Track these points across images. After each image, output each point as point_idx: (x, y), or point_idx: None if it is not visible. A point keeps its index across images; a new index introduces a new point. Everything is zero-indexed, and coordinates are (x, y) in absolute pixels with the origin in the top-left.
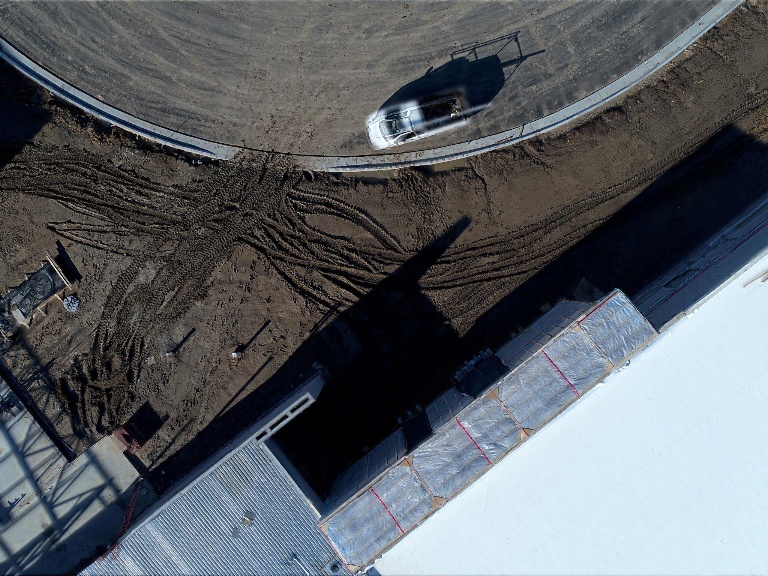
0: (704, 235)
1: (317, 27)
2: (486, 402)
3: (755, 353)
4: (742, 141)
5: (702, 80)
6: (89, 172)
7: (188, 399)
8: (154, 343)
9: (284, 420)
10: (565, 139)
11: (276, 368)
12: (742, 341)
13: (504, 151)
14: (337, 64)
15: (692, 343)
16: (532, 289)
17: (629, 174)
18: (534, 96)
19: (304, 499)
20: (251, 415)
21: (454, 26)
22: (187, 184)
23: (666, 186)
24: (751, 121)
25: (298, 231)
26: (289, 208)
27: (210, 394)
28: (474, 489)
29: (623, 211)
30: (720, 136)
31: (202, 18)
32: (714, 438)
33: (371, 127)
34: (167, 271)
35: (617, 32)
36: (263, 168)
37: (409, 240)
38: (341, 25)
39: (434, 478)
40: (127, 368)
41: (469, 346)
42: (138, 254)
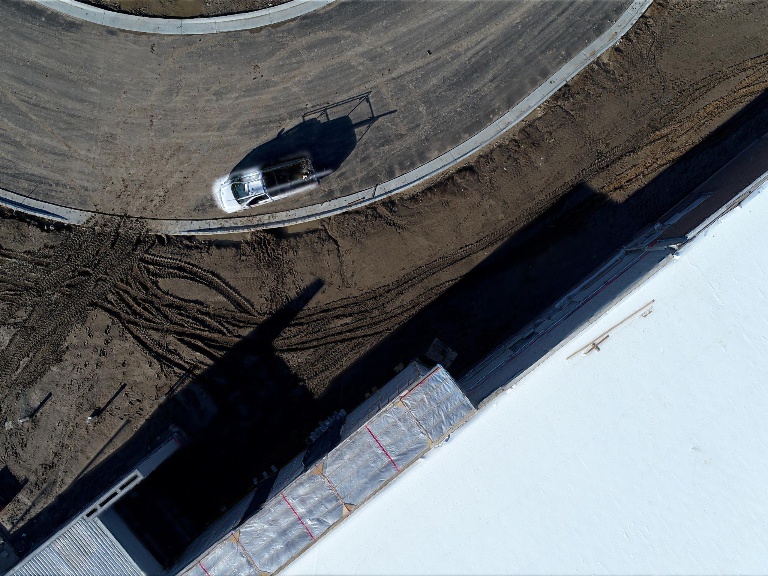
0: (555, 294)
1: (167, 90)
2: (310, 477)
3: (579, 423)
4: (592, 200)
5: (553, 139)
6: None
7: (46, 463)
8: (11, 408)
9: (114, 497)
10: (417, 200)
11: (133, 431)
12: (566, 412)
13: (357, 212)
14: (188, 127)
15: (517, 414)
16: (385, 349)
17: (480, 234)
18: (386, 157)
19: (139, 571)
20: (109, 477)
21: (305, 87)
22: (39, 250)
23: (517, 246)
24: (601, 180)
25: (151, 296)
26: (142, 273)
27: (68, 457)
28: (304, 560)
29: (474, 271)
30: (570, 195)
31: (51, 82)
32: (540, 506)
33: (223, 190)
34: (21, 337)
35: (468, 91)
36: (115, 233)
37: (262, 303)
38: (191, 87)
39: (259, 553)
40: None
41: (324, 406)
42: None
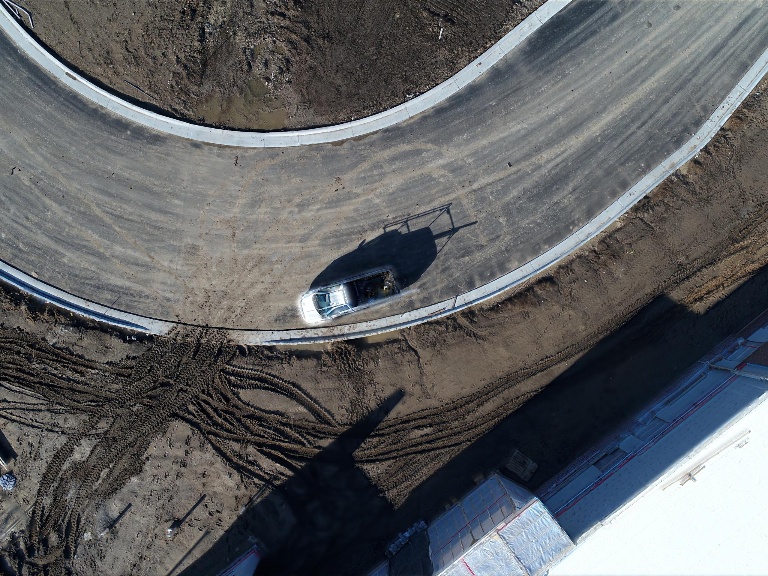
0: (636, 405)
1: (250, 201)
2: None
3: (675, 554)
4: (673, 311)
5: (633, 251)
6: (23, 350)
7: (125, 574)
8: (90, 519)
9: None
10: (497, 310)
11: (212, 542)
12: (662, 542)
13: (437, 323)
14: (270, 238)
15: (612, 545)
16: (466, 461)
17: (561, 346)
18: (466, 267)
19: None
20: None
21: (386, 199)
22: (121, 361)
23: (598, 357)
24: (682, 292)
25: (232, 407)
26: (223, 384)
27: (147, 569)
28: None
29: (555, 383)
30: (651, 307)
31: (135, 194)
32: None
33: (304, 300)
34: (102, 448)
35: (548, 203)
36: (197, 343)
37: (343, 414)
38: (274, 199)
39: None
40: (64, 544)
41: (404, 518)
42: (73, 432)
